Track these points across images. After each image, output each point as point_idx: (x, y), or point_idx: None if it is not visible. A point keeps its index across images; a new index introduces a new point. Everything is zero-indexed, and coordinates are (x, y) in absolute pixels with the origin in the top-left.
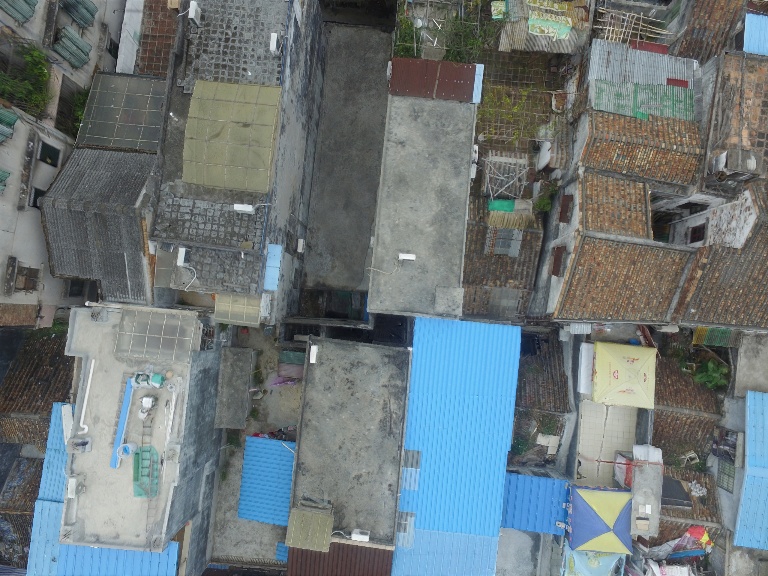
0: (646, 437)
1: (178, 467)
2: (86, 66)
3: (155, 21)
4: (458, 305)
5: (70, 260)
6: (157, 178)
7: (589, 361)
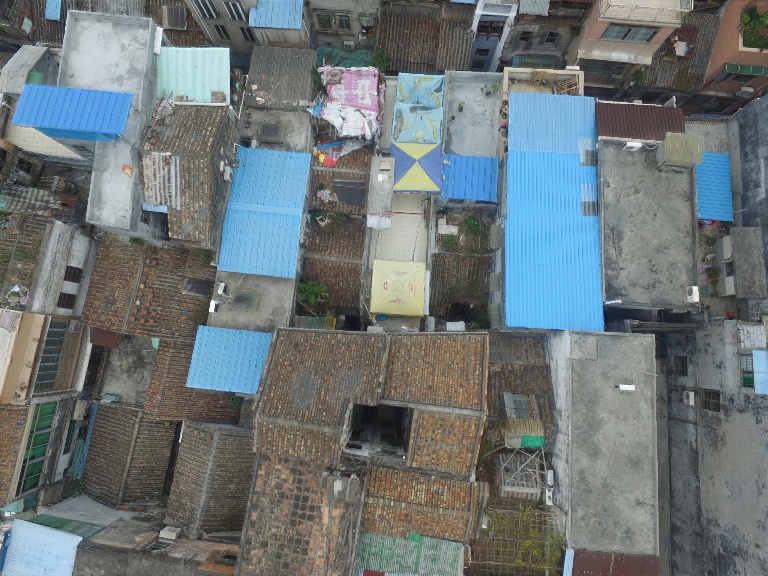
0: None
1: None
2: None
3: None
4: (576, 343)
5: None
6: None
7: (425, 299)
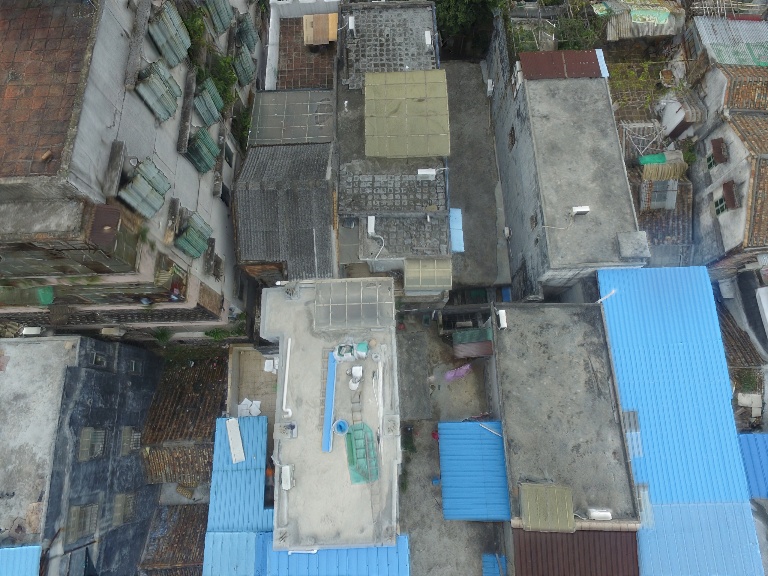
0: None
1: (398, 441)
2: (245, 89)
3: (290, 59)
4: (644, 247)
5: (258, 243)
6: (337, 158)
7: None
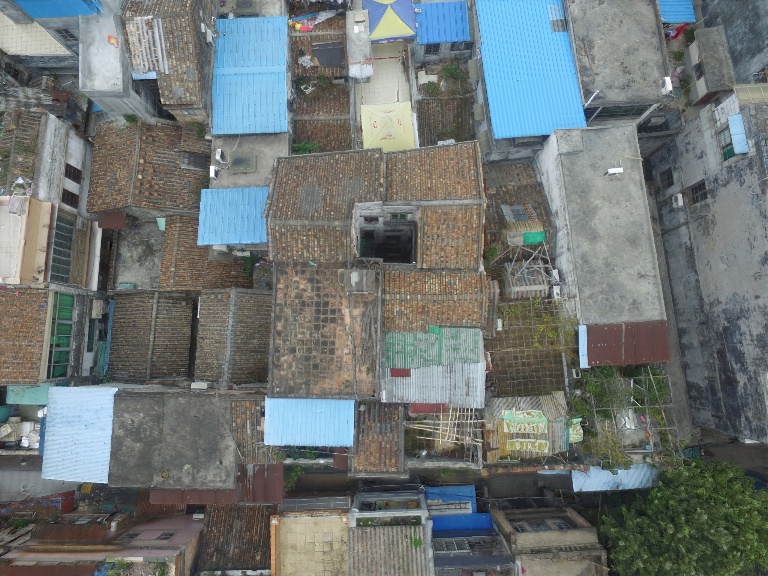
0: None
1: None
2: None
3: None
4: (562, 138)
5: None
6: None
7: (415, 138)
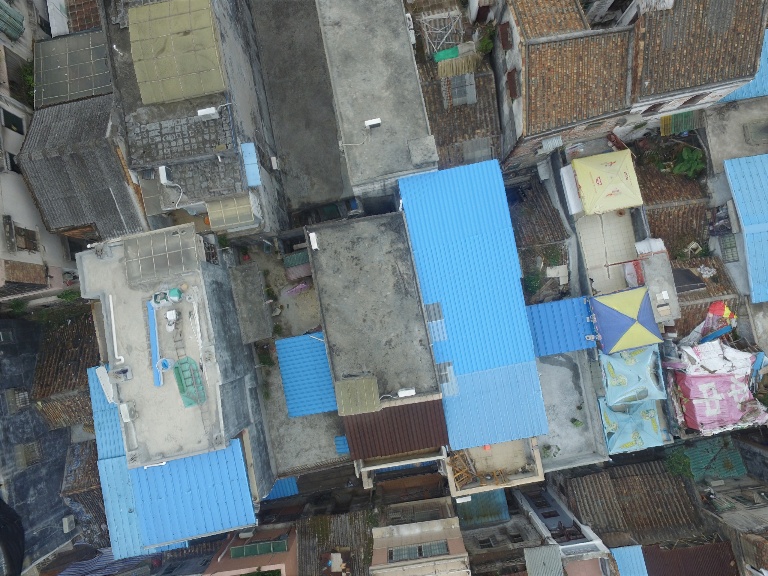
0: (645, 237)
1: (218, 367)
2: (23, 40)
3: None
4: (433, 151)
5: (61, 211)
6: (119, 110)
7: (572, 182)
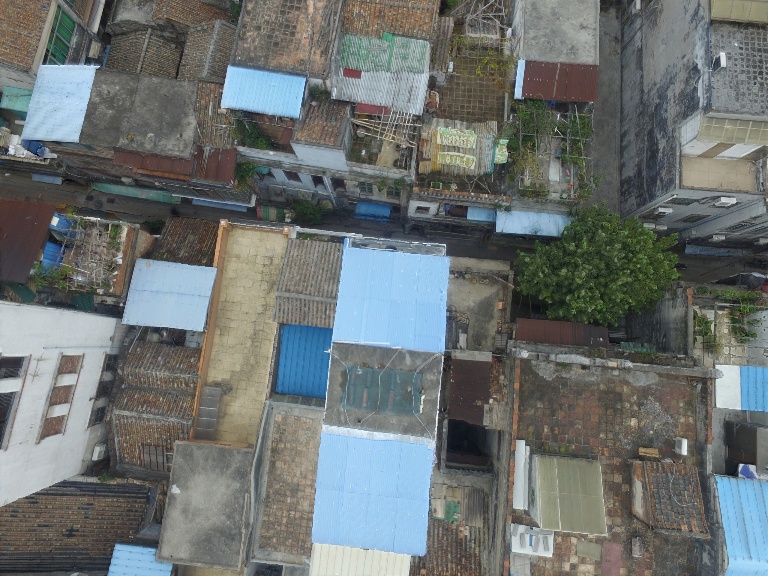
0: None
1: None
2: None
3: None
4: None
5: None
6: None
7: None
